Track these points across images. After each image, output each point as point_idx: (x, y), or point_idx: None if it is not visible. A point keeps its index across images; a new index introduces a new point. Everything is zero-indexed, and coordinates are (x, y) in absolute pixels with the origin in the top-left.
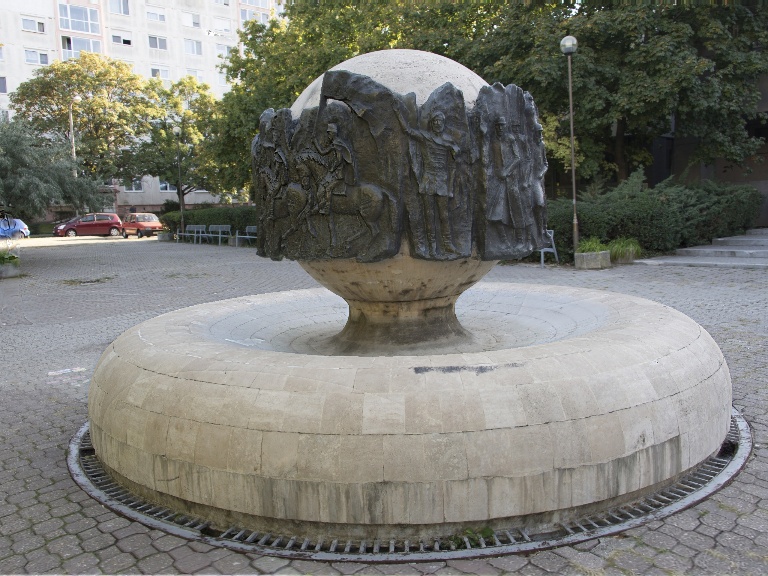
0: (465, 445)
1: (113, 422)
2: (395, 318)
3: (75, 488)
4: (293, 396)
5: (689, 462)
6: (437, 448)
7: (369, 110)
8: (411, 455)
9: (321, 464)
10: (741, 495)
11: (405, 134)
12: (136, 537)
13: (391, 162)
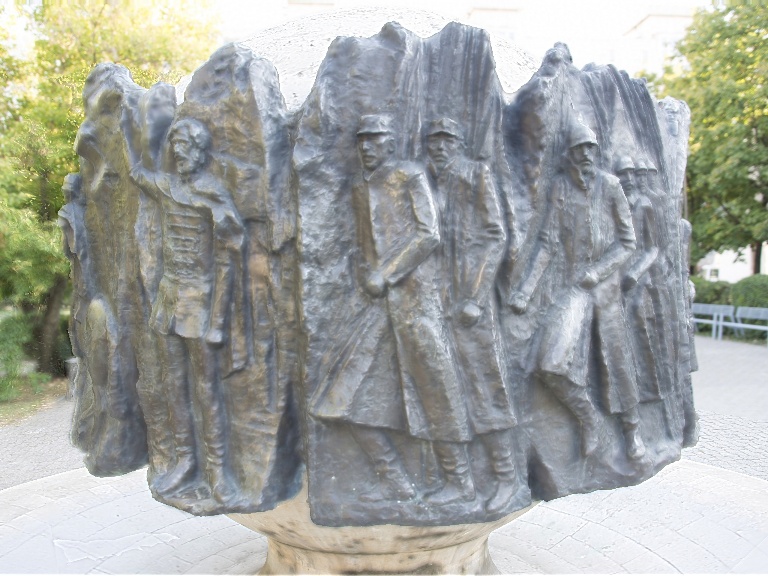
0: None
1: None
2: (292, 574)
3: None
4: None
5: None
6: None
7: (86, 136)
8: None
9: None
10: None
11: (134, 184)
12: None
13: (118, 251)
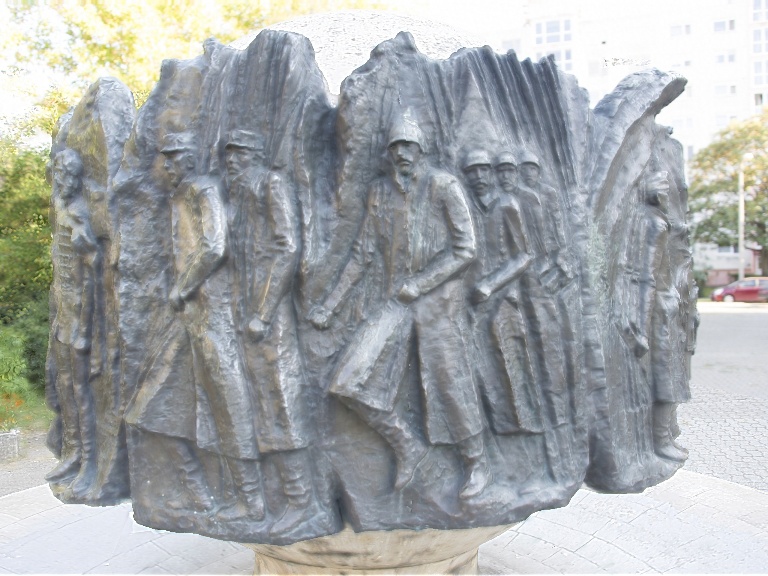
0: None
1: None
2: (258, 572)
3: None
4: None
5: None
6: None
7: (48, 168)
8: None
9: None
10: None
11: None
12: None
13: None
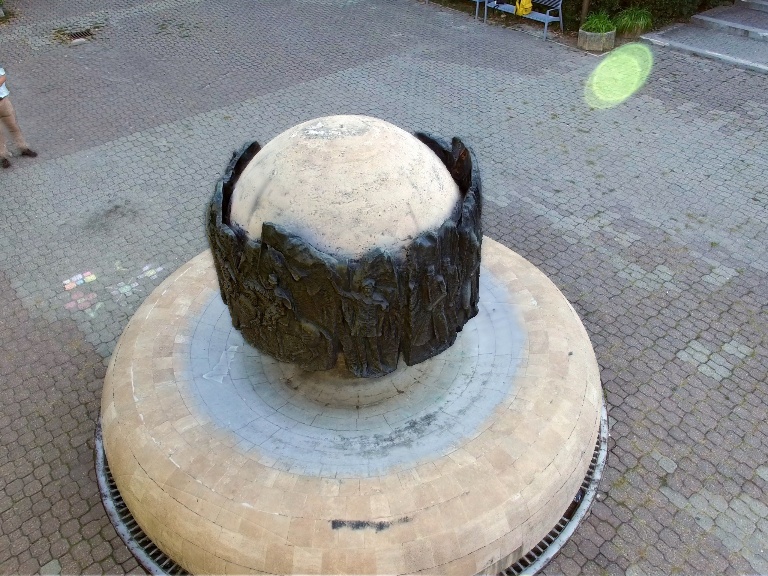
0: None
1: (123, 494)
2: None
3: (105, 520)
4: (245, 540)
5: (529, 550)
6: None
7: (304, 277)
8: None
9: None
10: (558, 575)
11: (338, 294)
12: None
13: (326, 312)
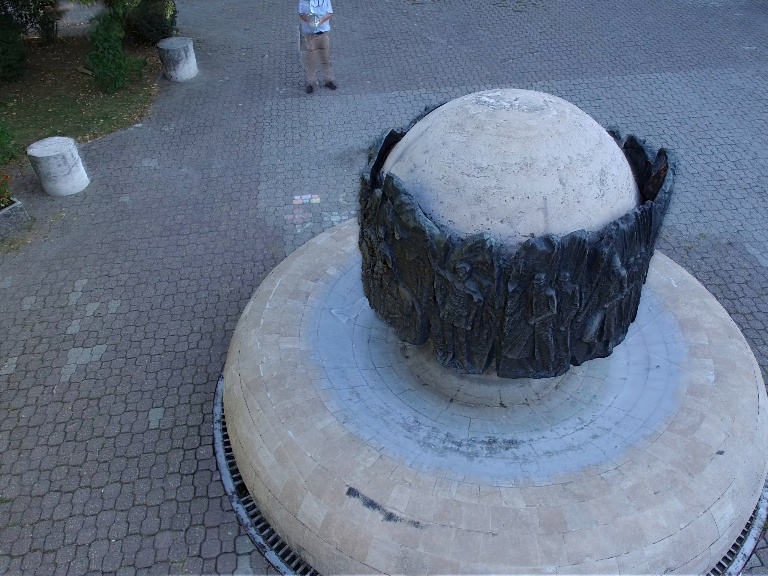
0: (349, 564)
1: None
2: None
3: (212, 396)
4: (275, 463)
5: None
6: (332, 555)
7: (404, 238)
8: (318, 548)
9: (276, 515)
10: None
11: None
12: (206, 473)
13: (421, 283)
